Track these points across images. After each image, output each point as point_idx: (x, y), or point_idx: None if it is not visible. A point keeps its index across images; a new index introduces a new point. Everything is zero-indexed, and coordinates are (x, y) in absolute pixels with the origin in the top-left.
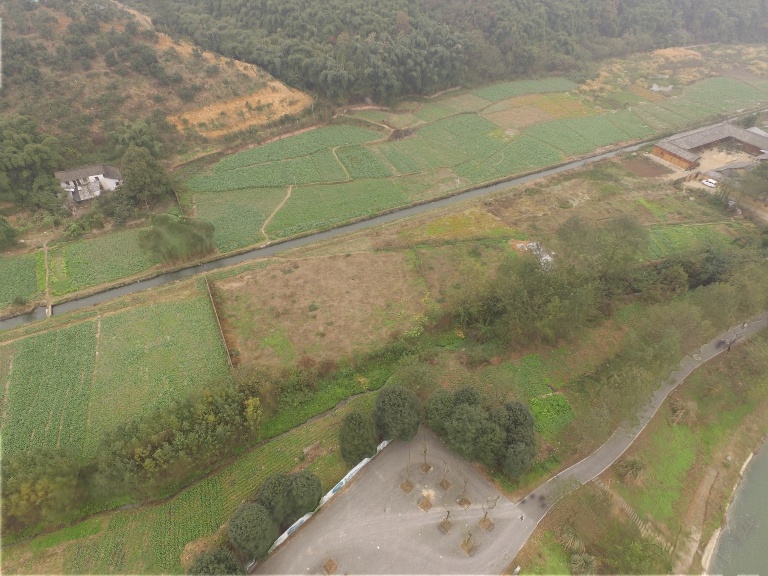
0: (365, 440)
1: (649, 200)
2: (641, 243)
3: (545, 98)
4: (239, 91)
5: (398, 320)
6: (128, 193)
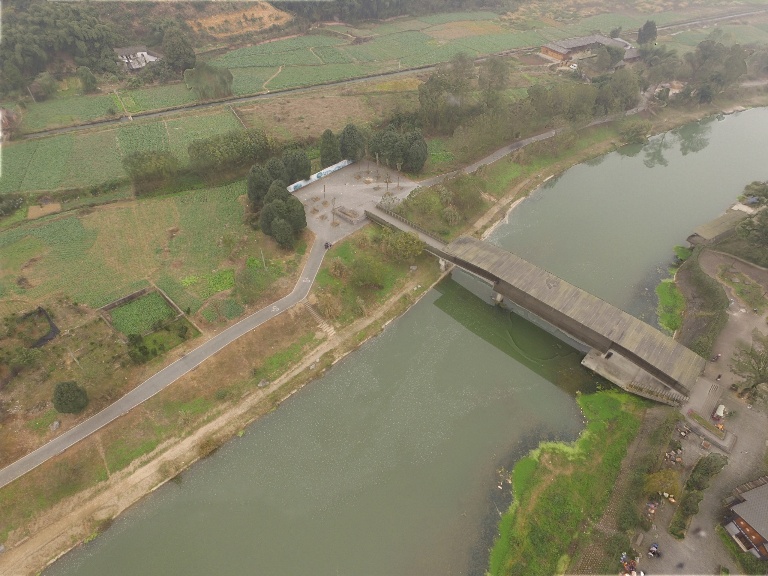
0: (334, 146)
1: (531, 75)
2: (504, 75)
3: (473, 23)
4: (237, 6)
5: (355, 123)
6: (168, 60)
